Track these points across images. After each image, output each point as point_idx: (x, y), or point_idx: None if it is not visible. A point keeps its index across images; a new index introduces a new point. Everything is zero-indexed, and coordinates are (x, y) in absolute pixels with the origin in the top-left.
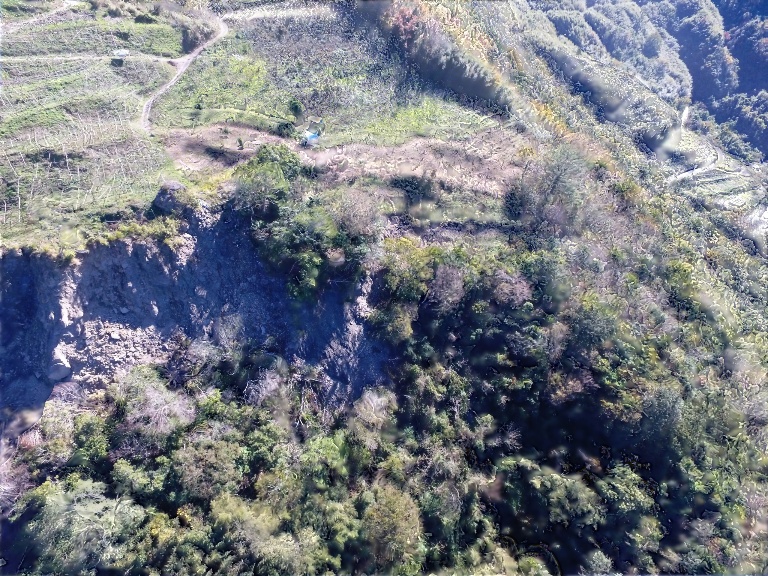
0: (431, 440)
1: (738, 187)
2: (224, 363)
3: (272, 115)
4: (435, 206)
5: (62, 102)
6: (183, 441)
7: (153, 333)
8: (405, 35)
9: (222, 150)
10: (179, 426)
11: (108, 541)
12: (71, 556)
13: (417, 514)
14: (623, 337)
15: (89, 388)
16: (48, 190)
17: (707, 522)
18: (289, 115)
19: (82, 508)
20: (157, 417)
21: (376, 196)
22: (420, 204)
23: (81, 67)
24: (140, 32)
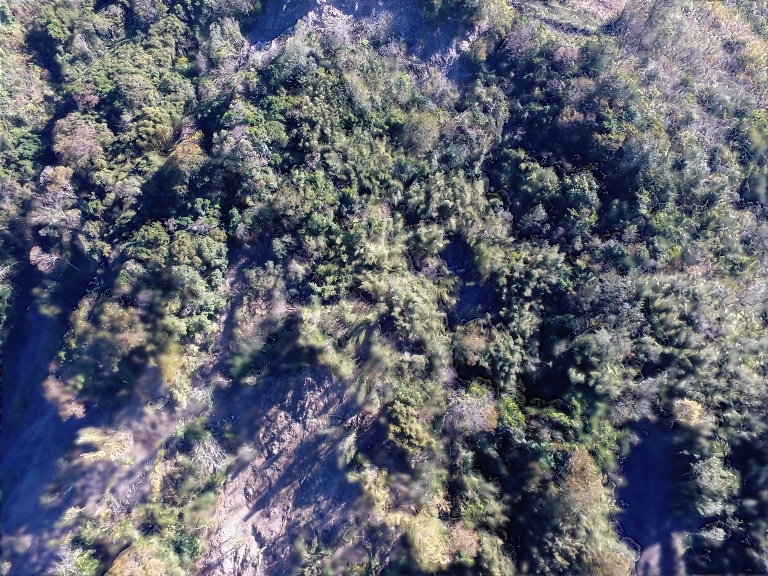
0: None
1: None
2: (376, 35)
3: None
4: (542, 2)
5: None
6: (343, 45)
7: (351, 18)
8: None
9: None
10: None
11: None
12: (285, 73)
13: (435, 122)
14: (633, 98)
15: None
16: None
17: (632, 224)
18: None
19: (298, 33)
20: (337, 34)
21: None
22: None
23: None
24: None
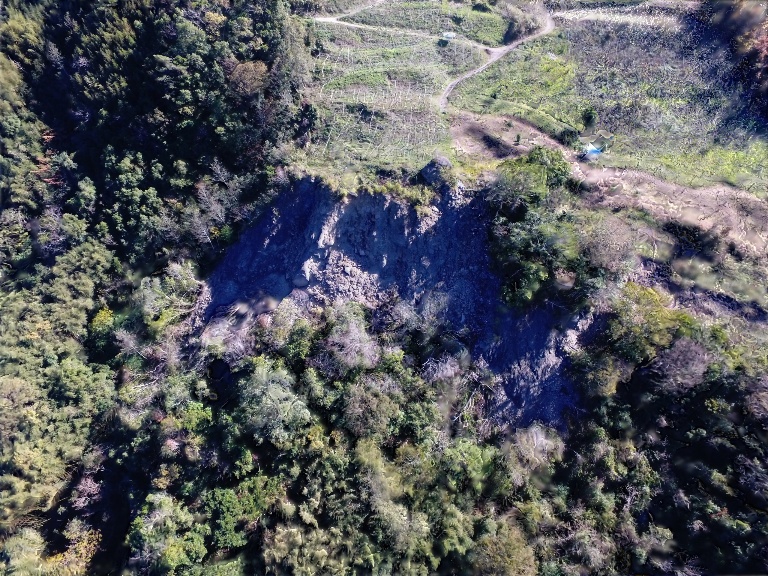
0: (583, 513)
1: None
2: (417, 332)
3: (561, 120)
4: (710, 269)
5: (388, 69)
6: (359, 379)
7: (375, 281)
8: (763, 63)
9: (498, 141)
10: (361, 366)
11: (278, 424)
12: (253, 420)
13: (533, 575)
14: None
15: (314, 302)
16: (350, 137)
17: None
18: (579, 124)
19: (272, 389)
20: (349, 350)
21: (639, 233)
22: (691, 260)
23: (414, 42)
24: (473, 19)
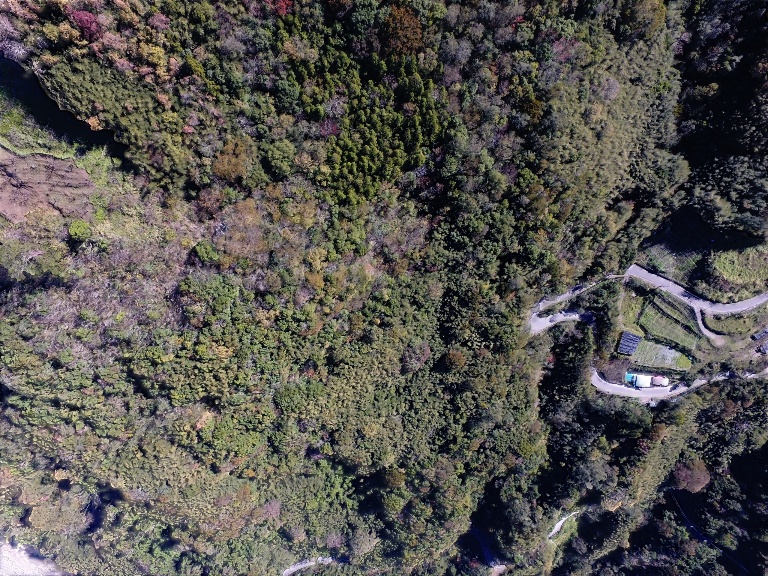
0: None
1: (672, 340)
2: None
3: None
4: None
5: None
6: None
7: None
8: None
9: None
10: None
11: None
12: None
13: None
14: None
15: None
16: None
17: None
18: None
19: None
20: None
21: None
22: None
23: None
24: None
